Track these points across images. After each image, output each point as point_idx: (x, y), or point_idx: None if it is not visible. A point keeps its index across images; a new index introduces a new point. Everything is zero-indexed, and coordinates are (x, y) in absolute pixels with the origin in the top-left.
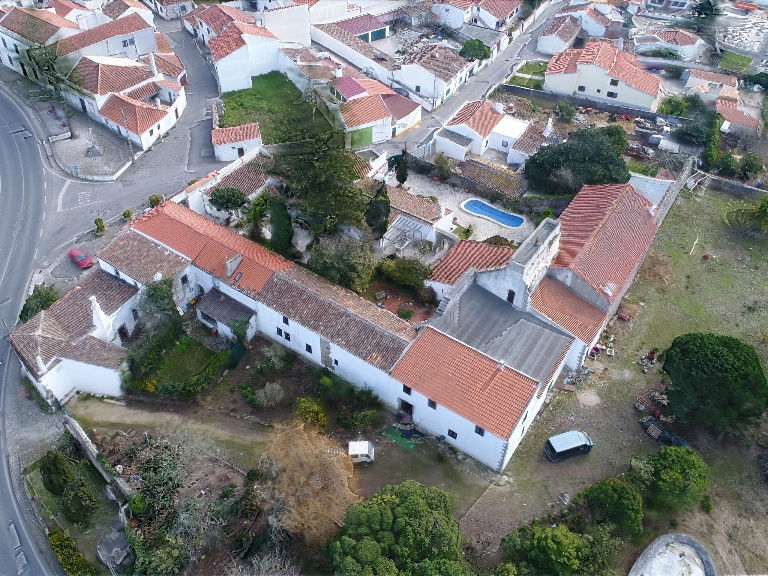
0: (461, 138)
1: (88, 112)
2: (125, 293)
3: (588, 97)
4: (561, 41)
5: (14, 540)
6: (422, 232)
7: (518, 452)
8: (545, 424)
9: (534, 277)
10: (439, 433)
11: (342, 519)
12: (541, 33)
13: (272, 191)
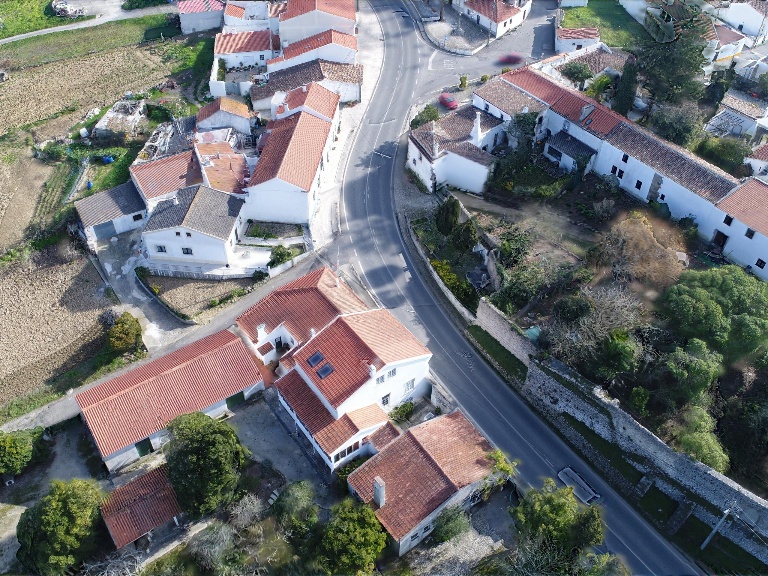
0: None
1: (453, 4)
2: (493, 122)
3: None
4: None
5: (403, 262)
6: (743, 127)
7: None
8: None
9: None
10: (746, 263)
11: (677, 276)
12: None
13: (631, 59)
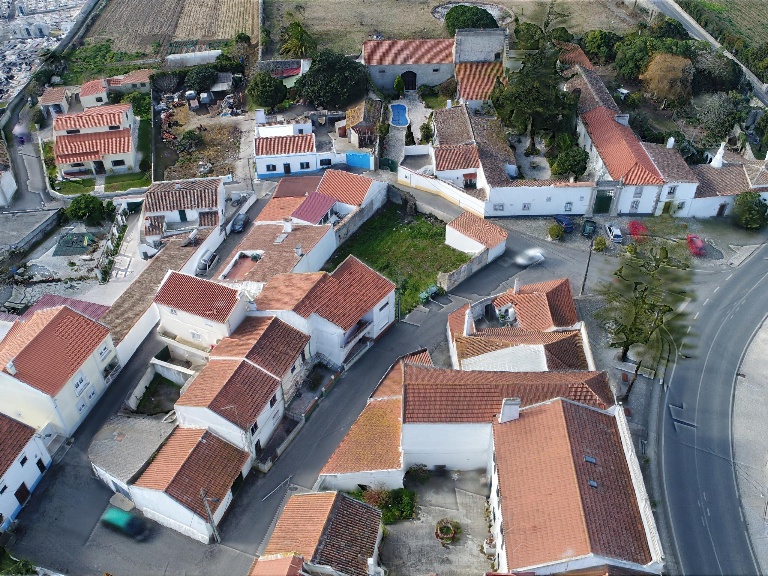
0: (322, 144)
1: None
2: None
3: None
4: (8, 174)
5: None
6: None
7: None
8: None
9: None
10: None
11: None
12: None
13: None
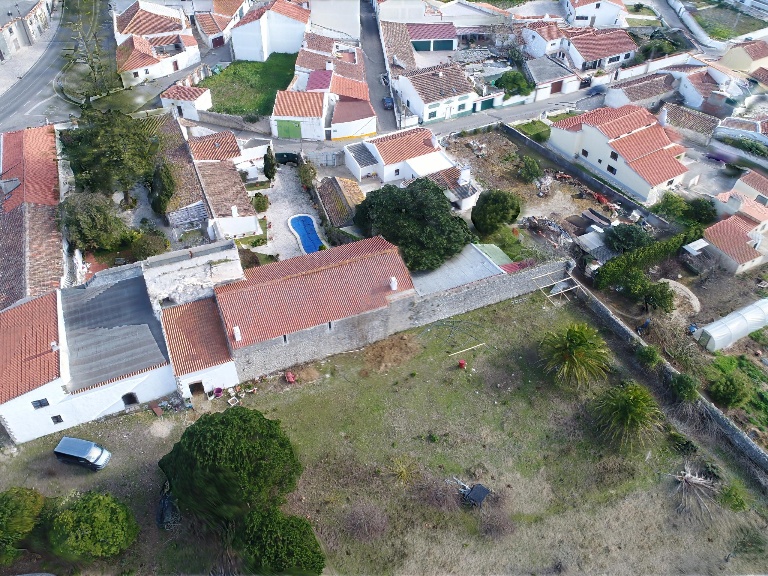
0: (367, 157)
1: None
2: None
3: (589, 165)
4: (626, 98)
5: None
6: None
7: (50, 437)
8: (99, 428)
9: (176, 289)
10: None
11: None
12: (615, 85)
13: (61, 134)
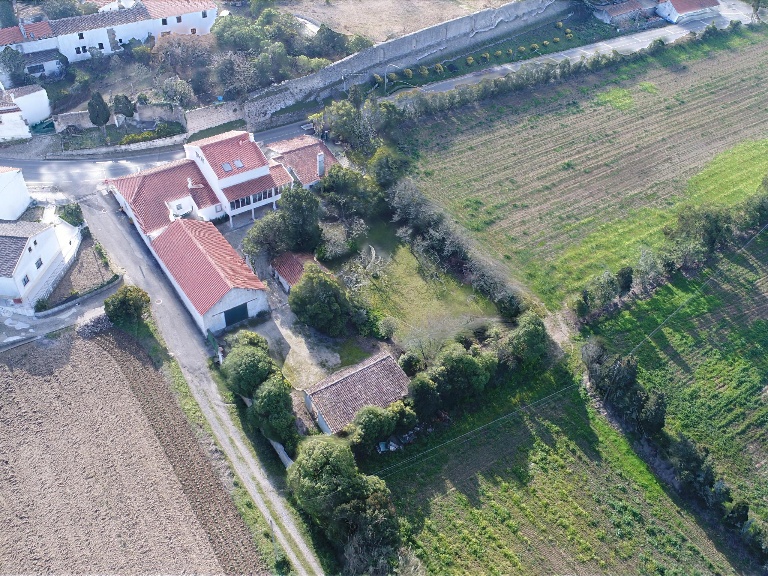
0: None
1: None
2: None
3: None
4: None
5: None
6: None
7: None
8: None
9: None
10: None
11: (216, 35)
12: None
13: None
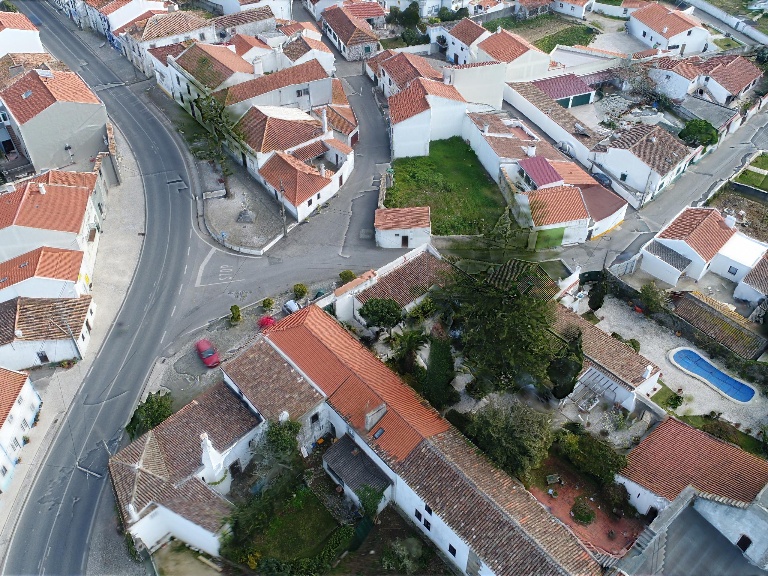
0: (676, 257)
1: (248, 168)
2: (245, 422)
3: None
4: None
5: None
6: (617, 393)
7: None
8: None
9: None
10: None
11: None
12: None
13: (436, 331)
